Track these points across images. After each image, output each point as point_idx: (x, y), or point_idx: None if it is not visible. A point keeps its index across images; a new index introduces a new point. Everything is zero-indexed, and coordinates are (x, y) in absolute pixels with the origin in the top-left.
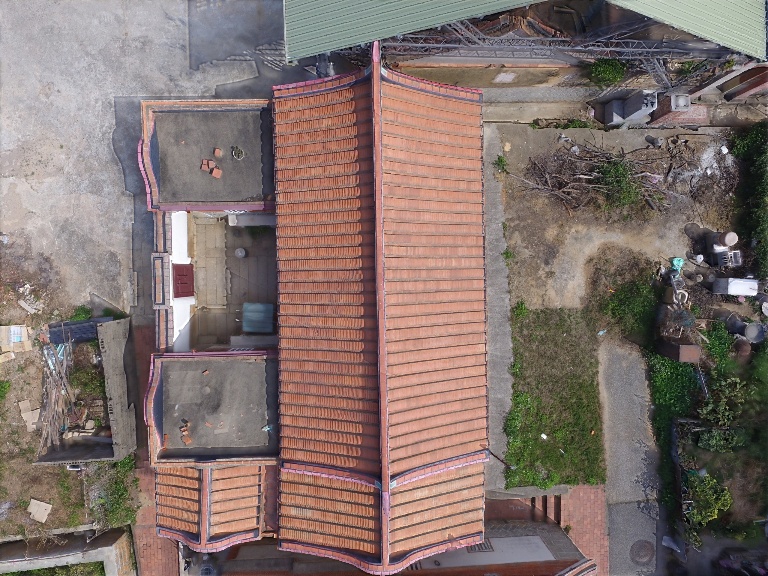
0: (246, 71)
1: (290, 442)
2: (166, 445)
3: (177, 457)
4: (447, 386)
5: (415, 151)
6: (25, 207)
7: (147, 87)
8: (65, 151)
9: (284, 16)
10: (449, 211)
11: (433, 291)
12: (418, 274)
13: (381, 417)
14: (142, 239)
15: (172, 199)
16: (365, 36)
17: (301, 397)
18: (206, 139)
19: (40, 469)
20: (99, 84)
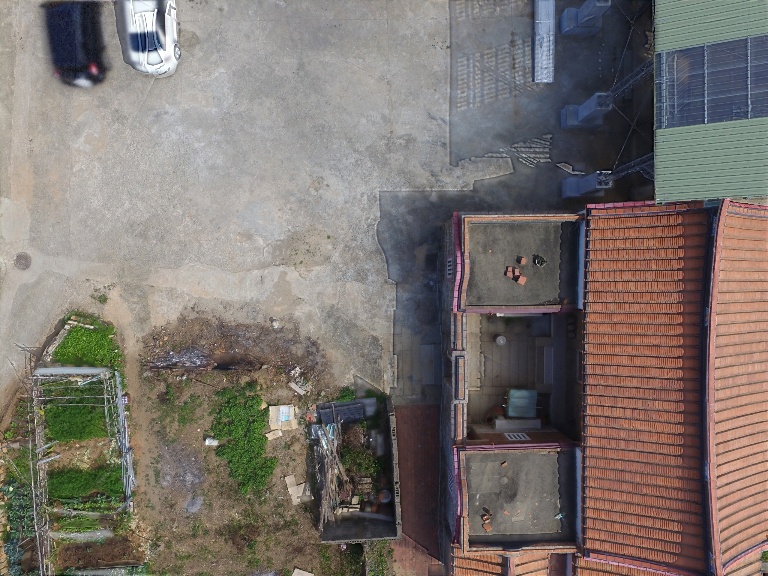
0: (502, 167)
1: (597, 534)
2: (469, 532)
3: (480, 544)
4: (745, 484)
5: (727, 269)
6: (294, 294)
7: (410, 182)
8: (332, 241)
9: (654, 162)
10: (747, 320)
11: (734, 396)
12: (727, 382)
13: (713, 521)
14: (403, 324)
15: (477, 303)
16: (753, 190)
17: (610, 493)
18: (511, 248)
19: (304, 540)
20: (365, 179)
